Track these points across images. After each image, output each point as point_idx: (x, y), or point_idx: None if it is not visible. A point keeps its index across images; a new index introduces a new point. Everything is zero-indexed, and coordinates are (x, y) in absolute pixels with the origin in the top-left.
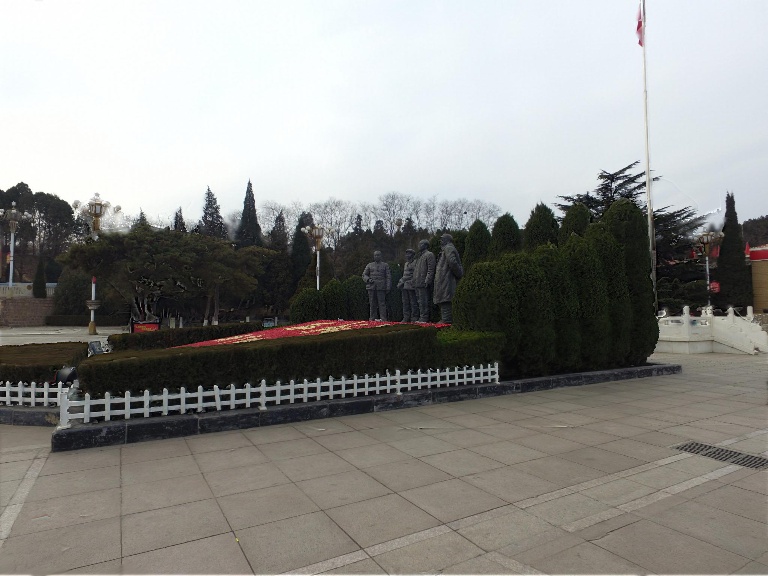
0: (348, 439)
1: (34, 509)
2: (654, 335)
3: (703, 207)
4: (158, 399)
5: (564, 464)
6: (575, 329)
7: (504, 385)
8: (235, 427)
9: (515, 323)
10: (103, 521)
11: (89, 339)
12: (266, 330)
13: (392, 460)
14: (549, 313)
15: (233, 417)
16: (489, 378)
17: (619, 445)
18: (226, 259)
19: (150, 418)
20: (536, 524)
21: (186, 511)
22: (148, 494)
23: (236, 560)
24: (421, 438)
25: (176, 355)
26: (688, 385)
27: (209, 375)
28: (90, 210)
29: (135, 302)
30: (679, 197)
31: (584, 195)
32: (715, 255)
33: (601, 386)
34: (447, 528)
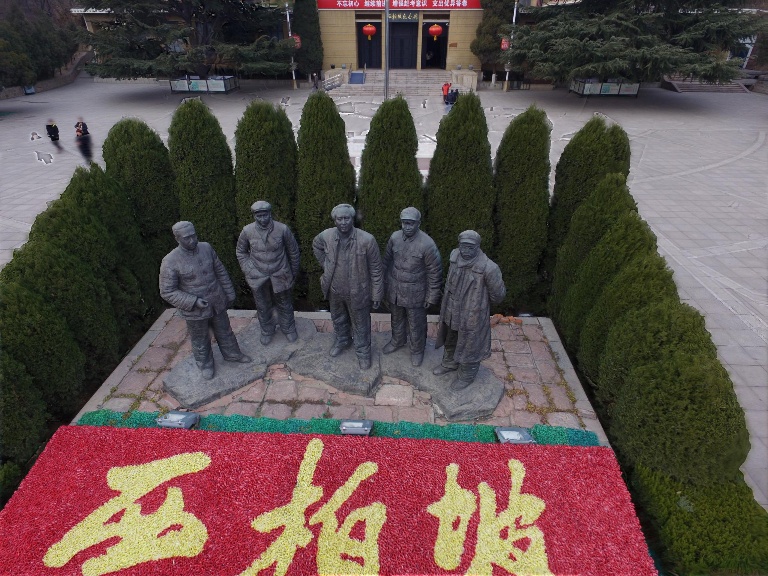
0: None
1: None
2: None
3: None
4: None
5: None
6: None
7: None
8: None
9: None
10: None
11: None
12: None
13: None
14: None
15: None
16: None
17: None
18: None
19: None
20: None
21: None
22: None
23: None
24: None
25: None
26: None
27: None
28: None
29: None
30: None
31: None
32: (292, 1)
33: None
34: None
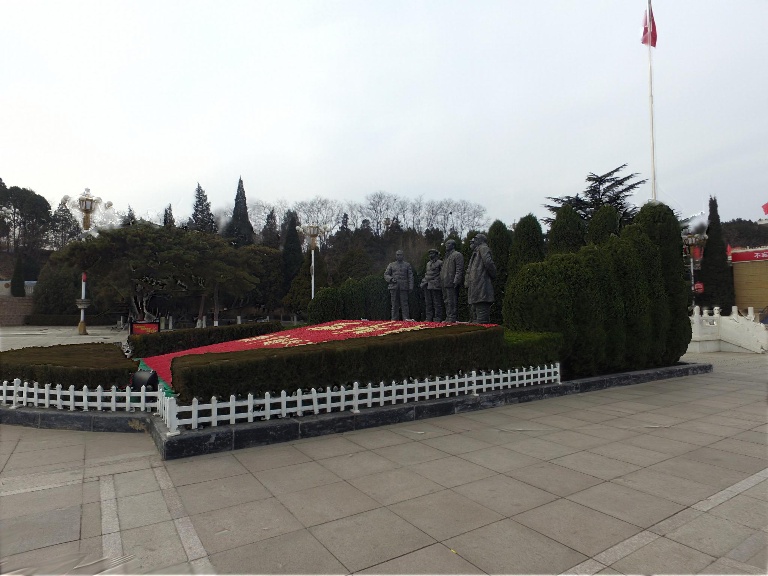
0: (458, 442)
1: (206, 523)
2: (688, 335)
3: (687, 210)
4: (260, 403)
5: (697, 465)
6: (621, 329)
7: (565, 385)
8: (332, 431)
9: (571, 323)
10: (293, 534)
11: (84, 339)
12: (288, 330)
13: (525, 463)
14: (600, 313)
15: (330, 421)
16: (552, 378)
17: (730, 445)
18: (227, 257)
19: (252, 423)
20: (735, 528)
21: (369, 521)
22: (311, 504)
23: (474, 573)
24: (530, 440)
25: (271, 357)
26: (732, 384)
27: (302, 378)
28: (80, 206)
29: (134, 301)
30: (664, 200)
31: (574, 197)
32: (699, 257)
33: (650, 385)
34: (653, 534)
